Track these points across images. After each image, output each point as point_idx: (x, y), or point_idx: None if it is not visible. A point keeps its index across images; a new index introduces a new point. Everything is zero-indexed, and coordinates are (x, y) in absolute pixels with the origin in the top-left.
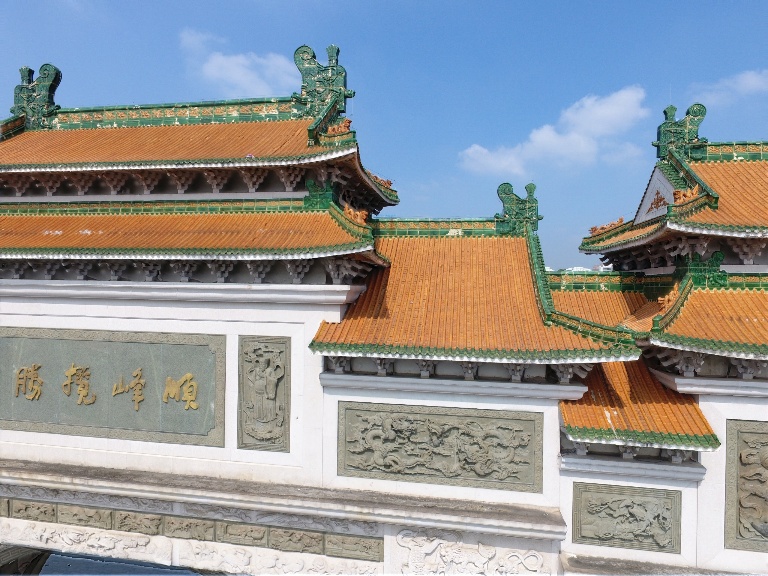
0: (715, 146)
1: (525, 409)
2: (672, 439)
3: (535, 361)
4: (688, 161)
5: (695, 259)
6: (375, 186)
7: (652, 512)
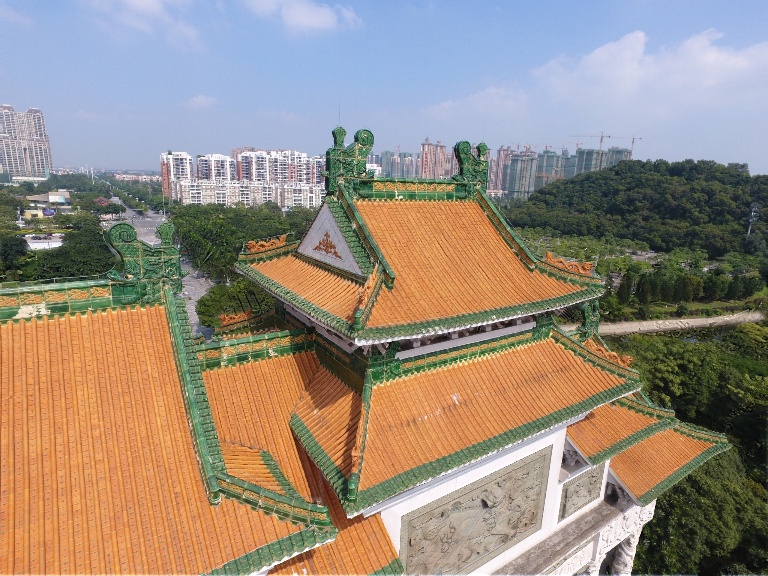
0: (380, 182)
1: None
2: None
3: None
4: (356, 198)
5: (375, 353)
6: None
7: None
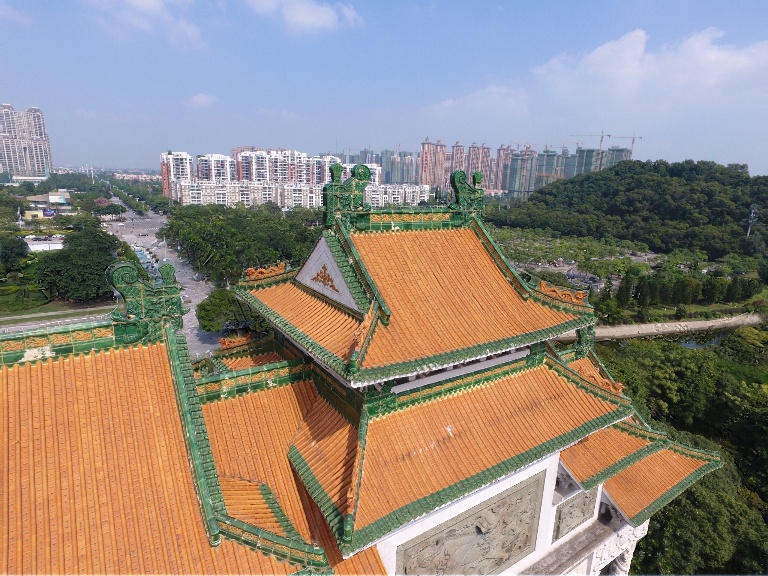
0: (377, 215)
1: None
2: None
3: None
4: (353, 231)
5: (371, 389)
6: None
7: None
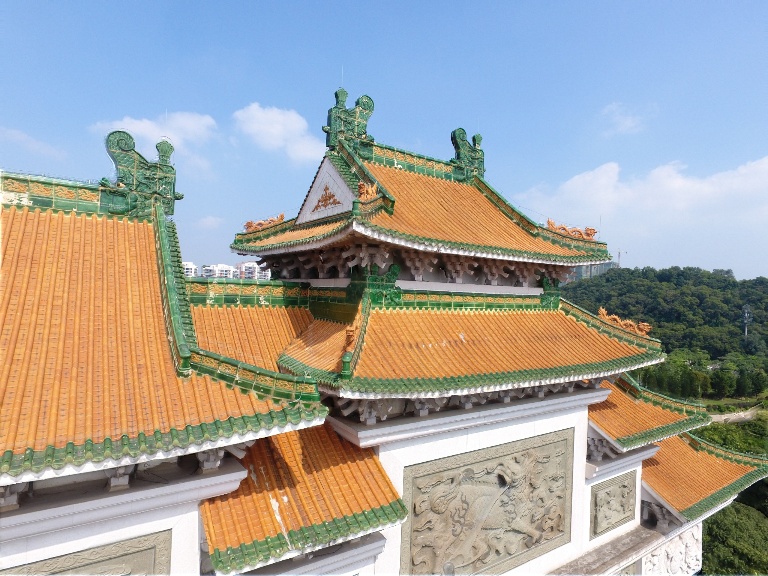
0: (380, 148)
1: (136, 533)
2: (359, 524)
3: (156, 455)
4: None
5: (374, 272)
6: None
7: None
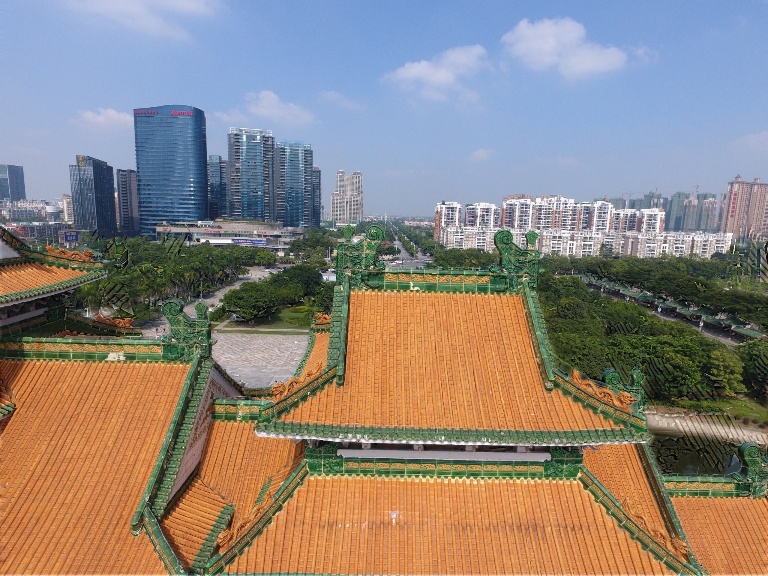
0: (392, 274)
1: None
2: None
3: None
4: (365, 289)
5: None
6: (6, 303)
7: None
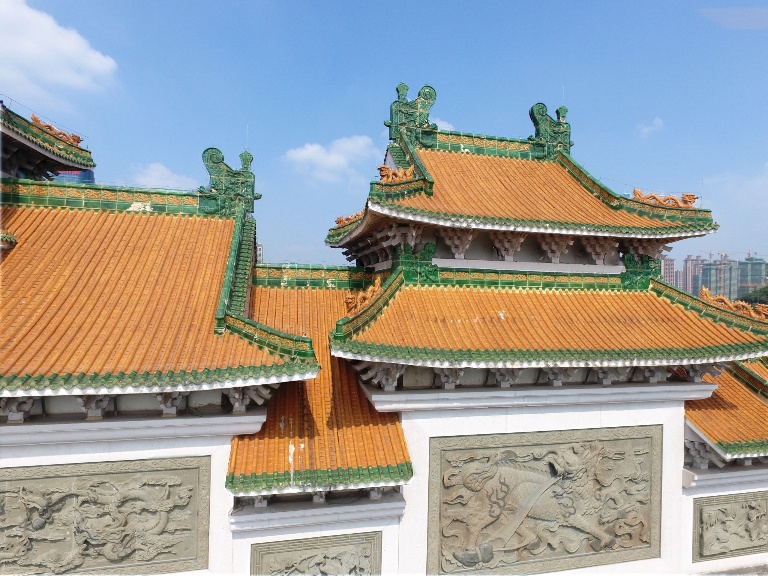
0: (444, 134)
1: (184, 453)
2: (359, 476)
3: (178, 388)
4: (419, 147)
5: (407, 251)
6: (7, 128)
7: (347, 565)
